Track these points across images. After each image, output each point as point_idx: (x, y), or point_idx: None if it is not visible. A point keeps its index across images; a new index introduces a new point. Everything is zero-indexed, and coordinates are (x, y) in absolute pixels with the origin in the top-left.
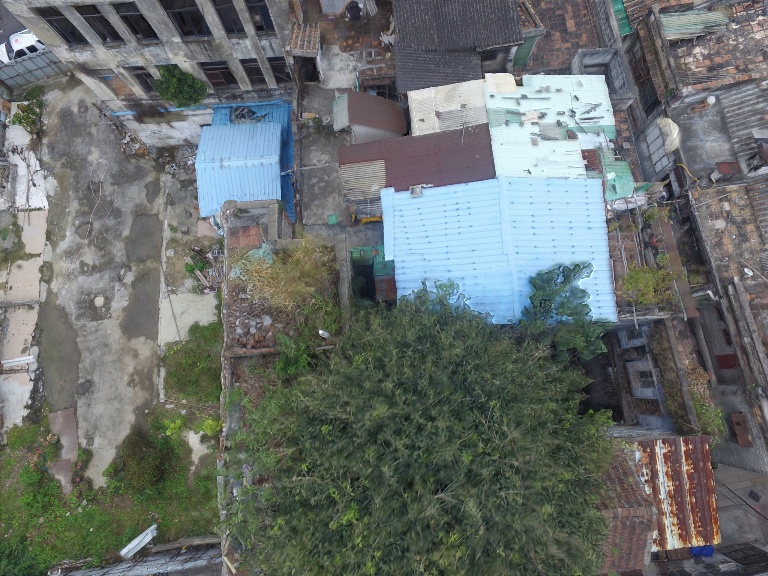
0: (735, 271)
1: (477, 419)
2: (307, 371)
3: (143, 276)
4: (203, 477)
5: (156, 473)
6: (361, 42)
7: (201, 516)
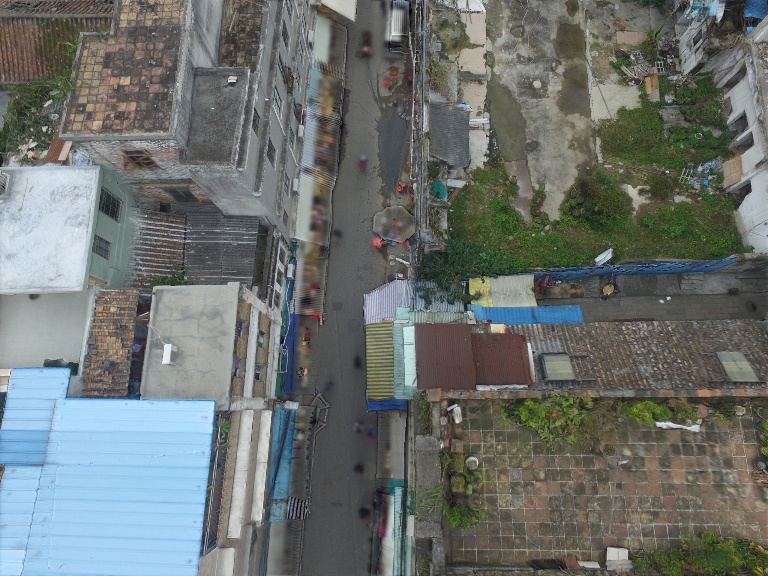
0: None
1: None
2: None
3: (572, 69)
4: None
5: None
6: None
7: (650, 246)
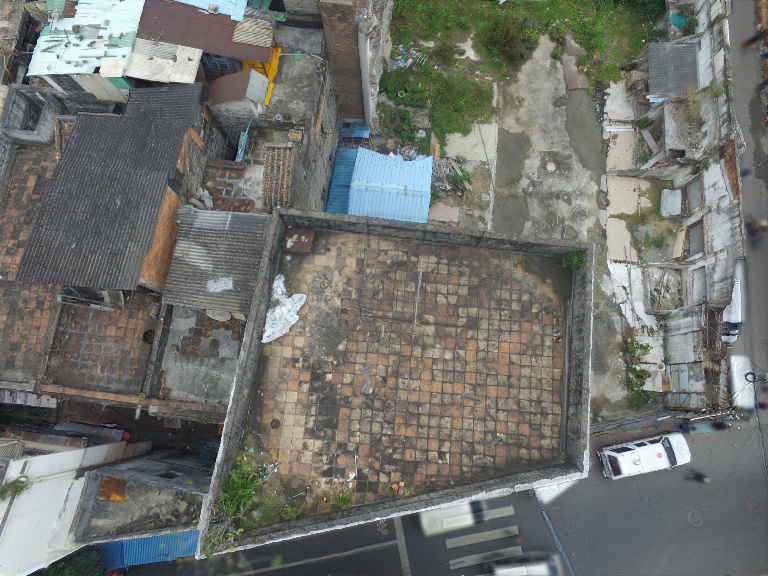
0: None
1: None
2: None
3: (512, 182)
4: (463, 26)
5: None
6: (232, 206)
7: (466, 5)
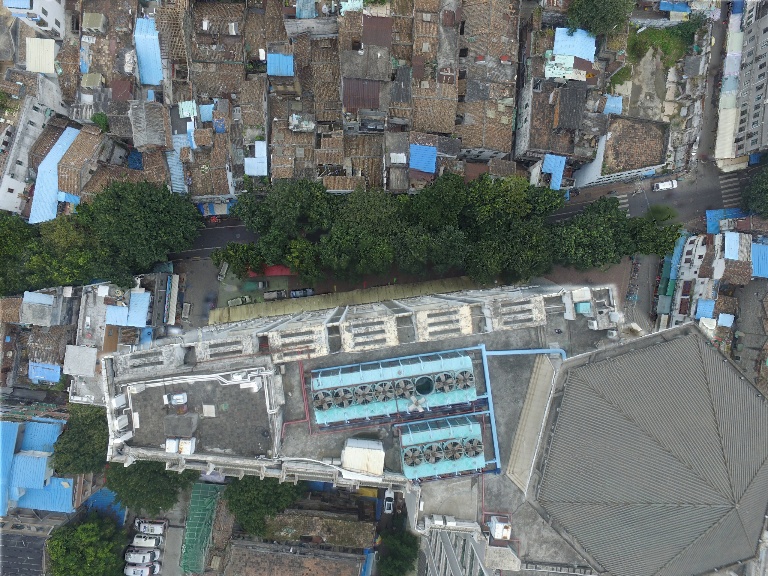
0: (514, 42)
1: (604, 2)
2: (617, 24)
3: (635, 103)
4: None
5: (636, 44)
6: None
7: None
